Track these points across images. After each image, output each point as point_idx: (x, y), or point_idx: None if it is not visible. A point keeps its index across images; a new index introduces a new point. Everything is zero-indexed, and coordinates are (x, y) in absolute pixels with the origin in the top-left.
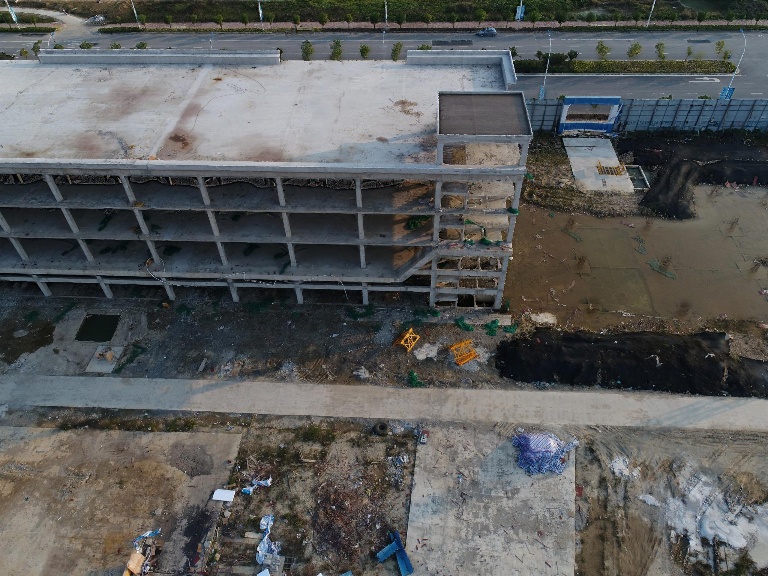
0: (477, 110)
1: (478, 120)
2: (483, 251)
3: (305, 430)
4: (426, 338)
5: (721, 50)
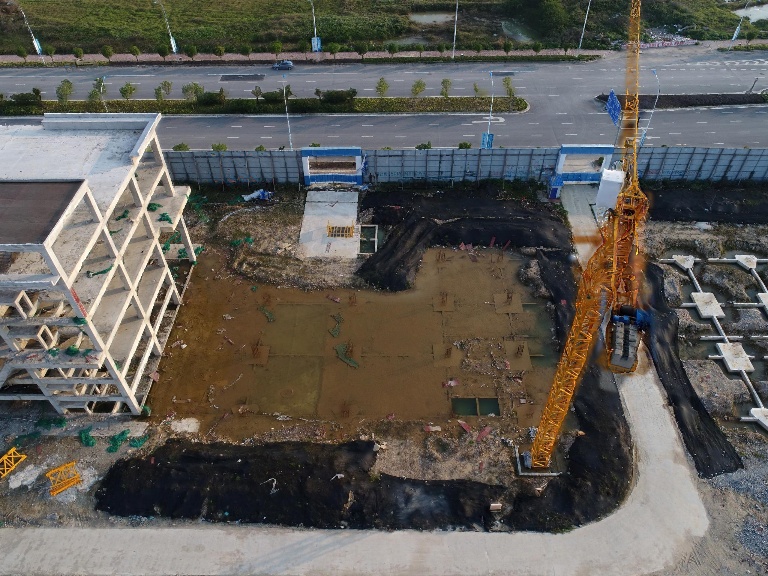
0: (14, 206)
1: (2, 221)
2: (63, 364)
3: None
4: (34, 458)
5: (509, 87)
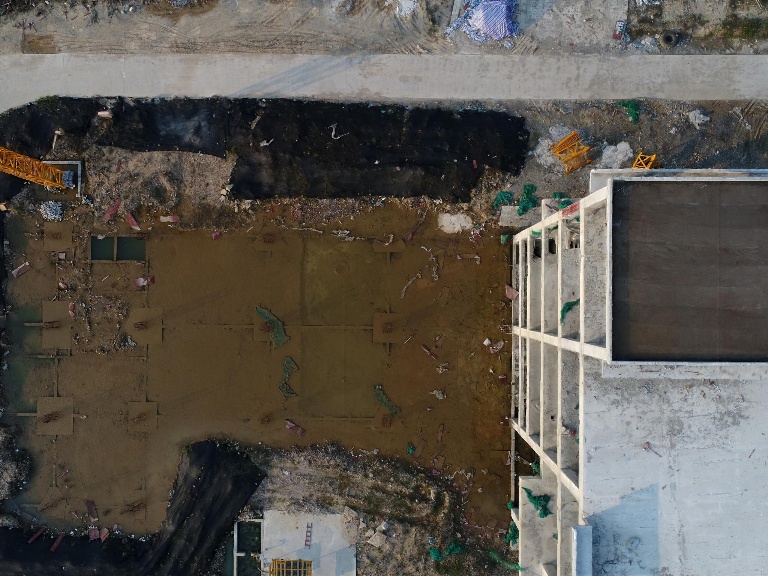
0: (712, 288)
1: (712, 246)
2: None
3: (759, 34)
4: None
5: None
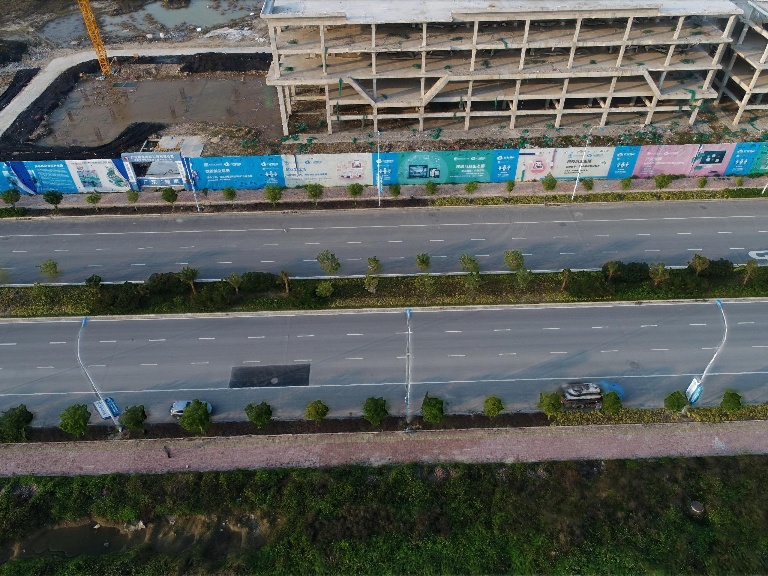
0: None
1: None
2: None
3: None
4: None
5: None
